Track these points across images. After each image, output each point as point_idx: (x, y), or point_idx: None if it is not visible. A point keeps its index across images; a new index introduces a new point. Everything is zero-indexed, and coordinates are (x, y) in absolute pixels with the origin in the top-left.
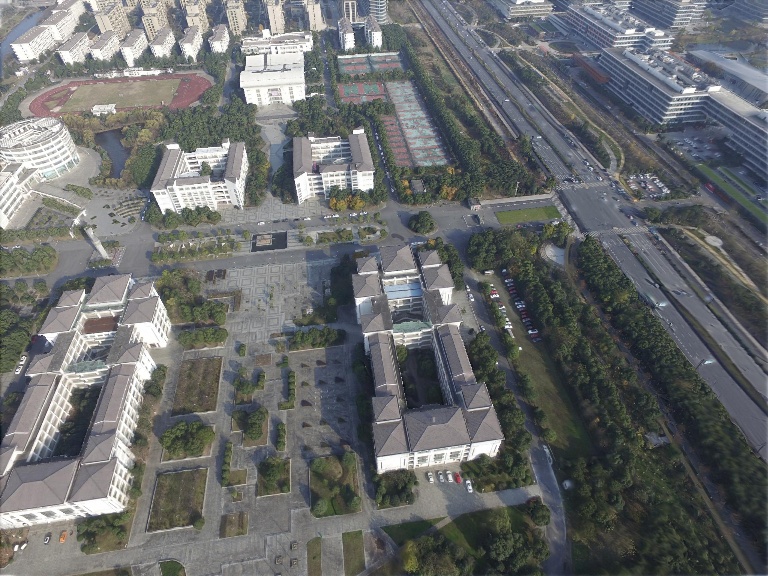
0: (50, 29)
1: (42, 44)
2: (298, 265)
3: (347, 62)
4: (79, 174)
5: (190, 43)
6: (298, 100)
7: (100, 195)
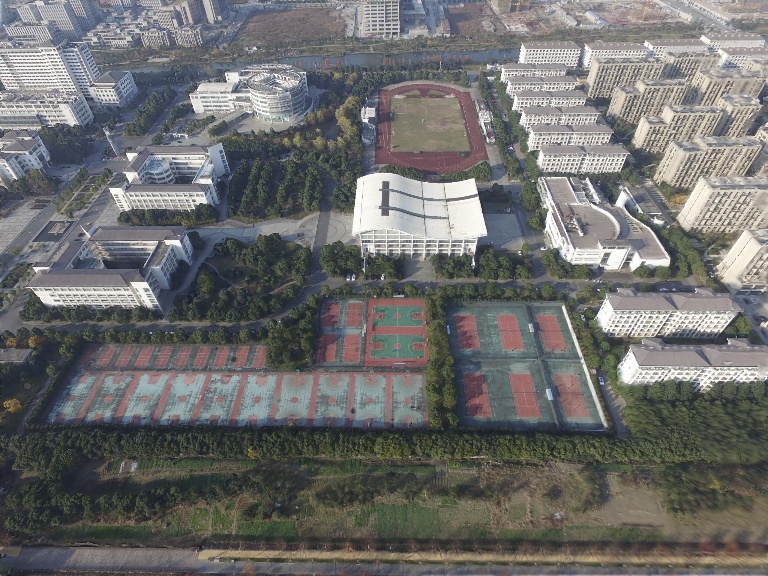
0: (588, 52)
1: (549, 58)
2: (0, 249)
3: (541, 320)
4: (258, 126)
5: (534, 132)
6: (355, 246)
7: (214, 140)
